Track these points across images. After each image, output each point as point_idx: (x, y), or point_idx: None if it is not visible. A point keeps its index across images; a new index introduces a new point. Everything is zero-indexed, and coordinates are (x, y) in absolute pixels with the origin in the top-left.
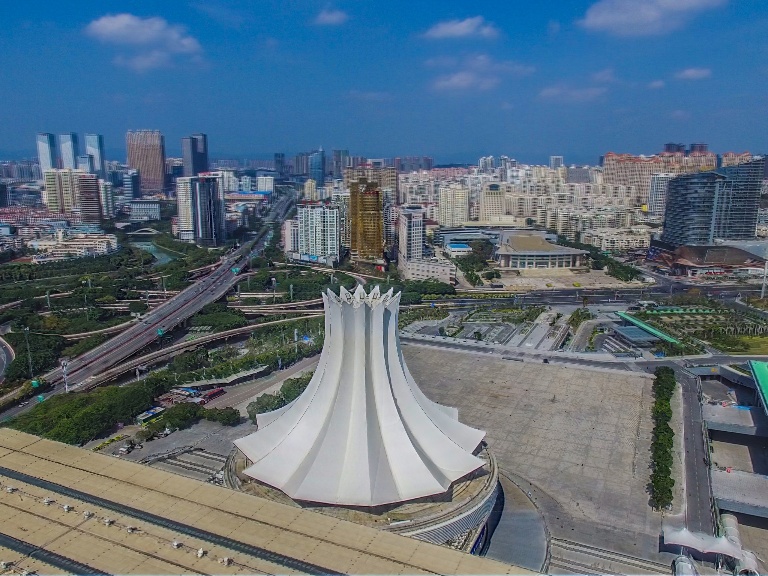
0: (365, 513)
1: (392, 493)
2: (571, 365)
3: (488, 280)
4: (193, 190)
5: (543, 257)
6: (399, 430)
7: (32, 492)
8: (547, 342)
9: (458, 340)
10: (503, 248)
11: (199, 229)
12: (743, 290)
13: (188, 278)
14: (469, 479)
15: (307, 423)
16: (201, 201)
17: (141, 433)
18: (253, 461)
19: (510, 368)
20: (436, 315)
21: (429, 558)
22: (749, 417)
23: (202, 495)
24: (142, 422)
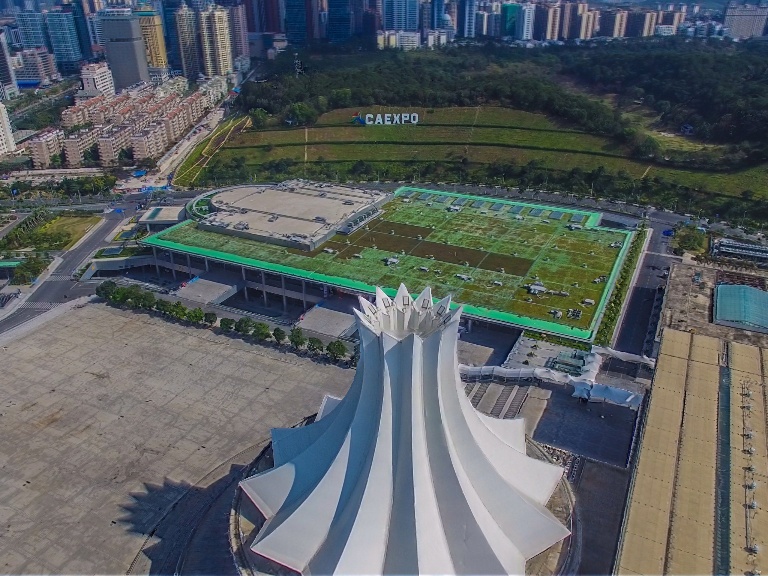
0: None
1: None
2: None
3: None
4: None
5: None
6: None
7: None
8: None
9: None
10: None
11: None
12: None
13: None
14: None
15: None
16: None
17: None
18: None
19: None
20: None
21: (667, 423)
22: (213, 283)
23: None
24: None
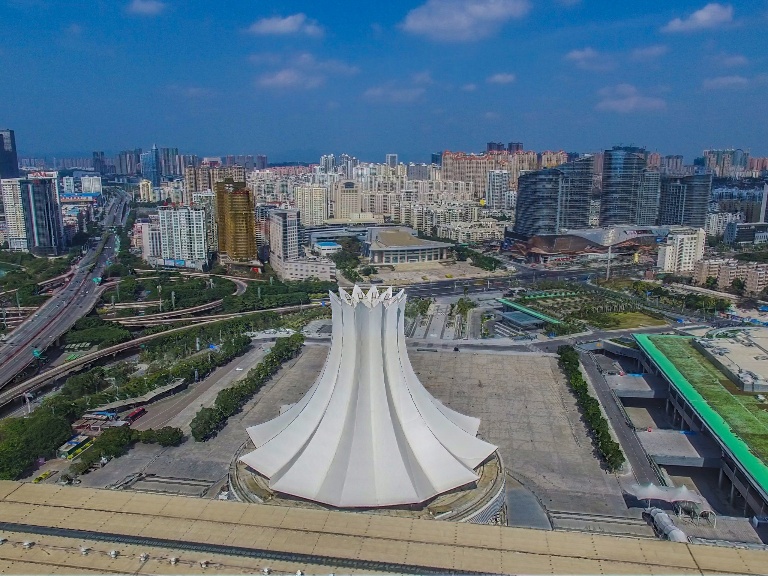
0: (406, 511)
1: (428, 487)
2: (479, 351)
3: (366, 276)
4: (24, 193)
5: (414, 251)
6: (420, 425)
7: (55, 543)
8: (449, 332)
9: None
10: (375, 244)
11: (34, 236)
12: (590, 273)
13: (38, 291)
14: (481, 465)
15: (326, 429)
16: (36, 205)
17: (76, 466)
18: (268, 476)
19: (428, 359)
20: (330, 314)
21: (518, 541)
22: (645, 383)
23: (256, 517)
24: (67, 454)
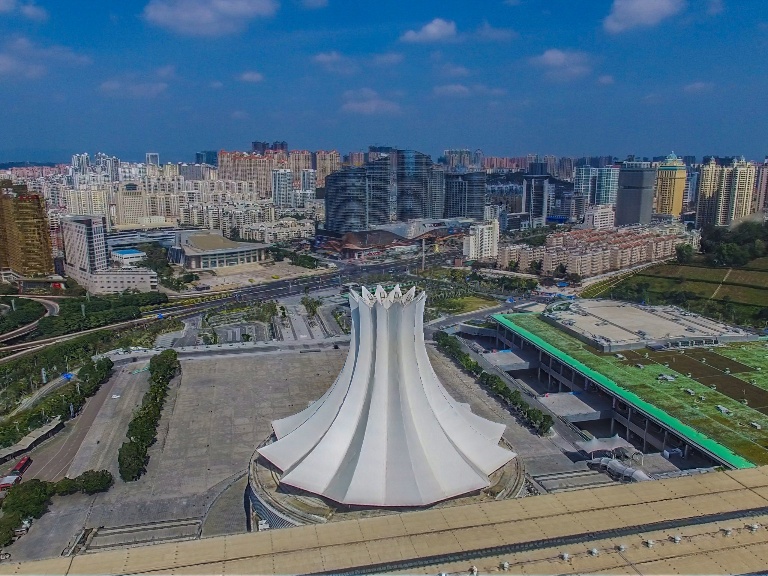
0: (468, 498)
1: None
2: None
3: (188, 283)
4: None
5: (232, 254)
6: (453, 415)
7: None
8: (316, 331)
9: (235, 345)
10: (188, 249)
11: None
12: (404, 265)
13: None
14: None
15: (371, 434)
16: None
17: None
18: (318, 493)
19: (317, 359)
20: (174, 326)
21: (613, 497)
22: (517, 356)
23: (376, 530)
24: None
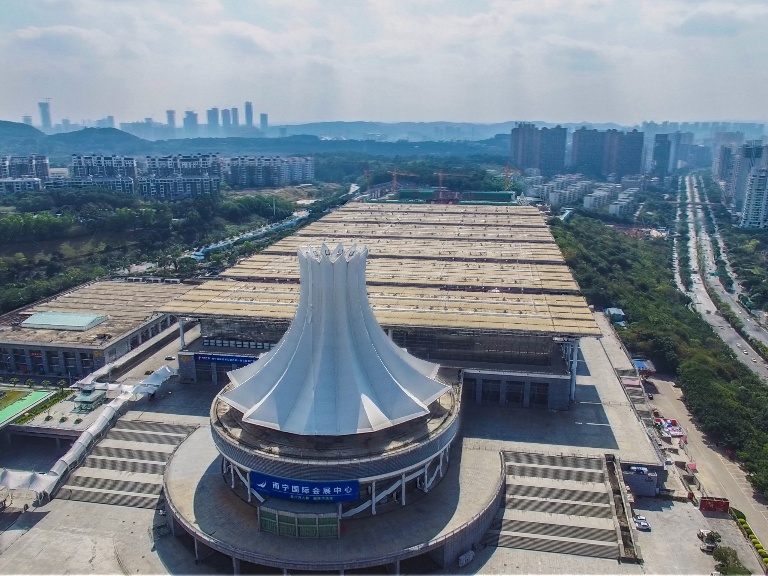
0: None
1: None
2: None
3: None
4: None
5: None
6: None
7: None
8: None
9: None
10: None
11: None
12: None
13: None
14: None
15: None
16: None
17: (725, 549)
18: None
19: None
20: None
21: (271, 313)
22: None
23: None
24: None
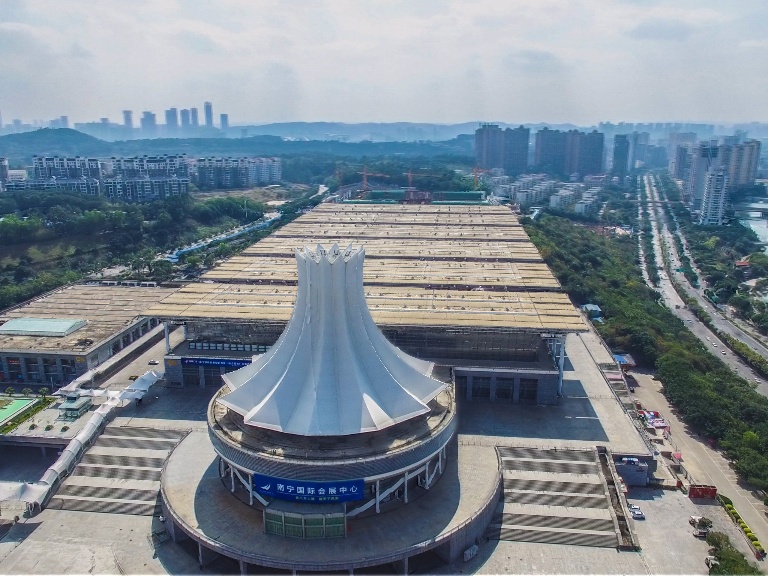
0: None
1: None
2: None
3: None
4: None
5: None
6: None
7: None
8: None
9: None
10: None
11: None
12: None
13: None
14: None
15: None
16: None
17: (718, 534)
18: None
19: None
20: None
21: (260, 315)
22: None
23: (394, 319)
24: None
